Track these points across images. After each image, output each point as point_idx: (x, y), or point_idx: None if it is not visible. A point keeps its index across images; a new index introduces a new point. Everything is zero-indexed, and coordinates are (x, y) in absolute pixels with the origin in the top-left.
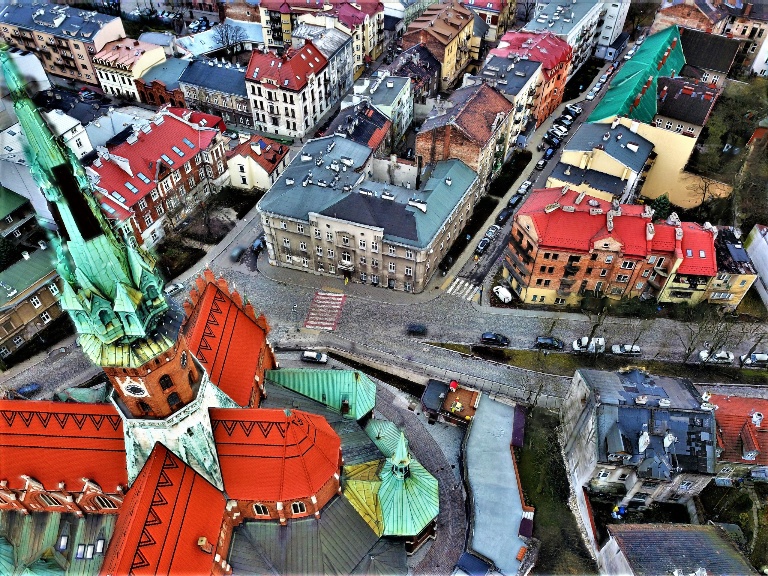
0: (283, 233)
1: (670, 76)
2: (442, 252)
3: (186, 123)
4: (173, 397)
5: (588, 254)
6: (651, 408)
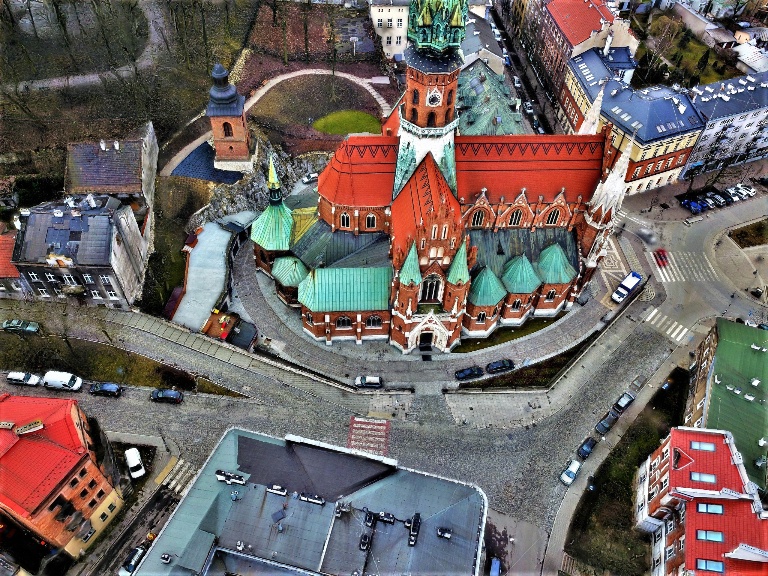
0: None
1: None
2: None
3: None
4: None
5: None
6: None
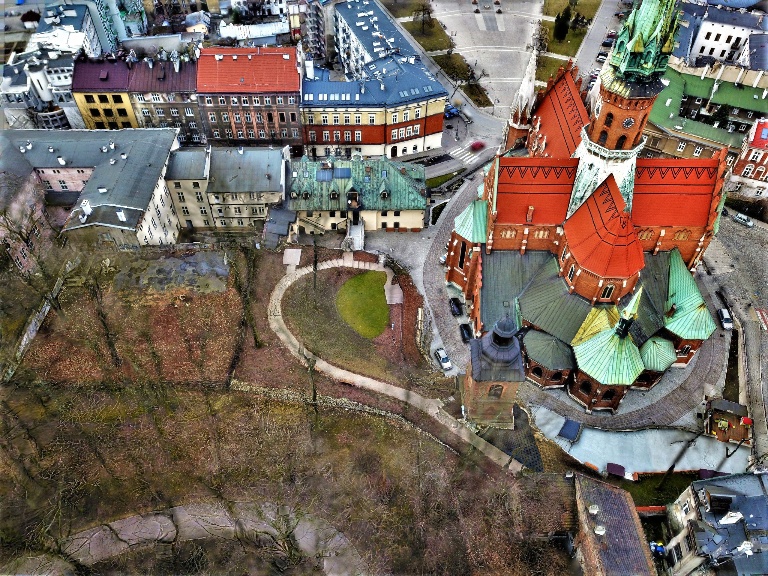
0: None
1: None
2: None
3: None
4: (605, 137)
5: None
6: None
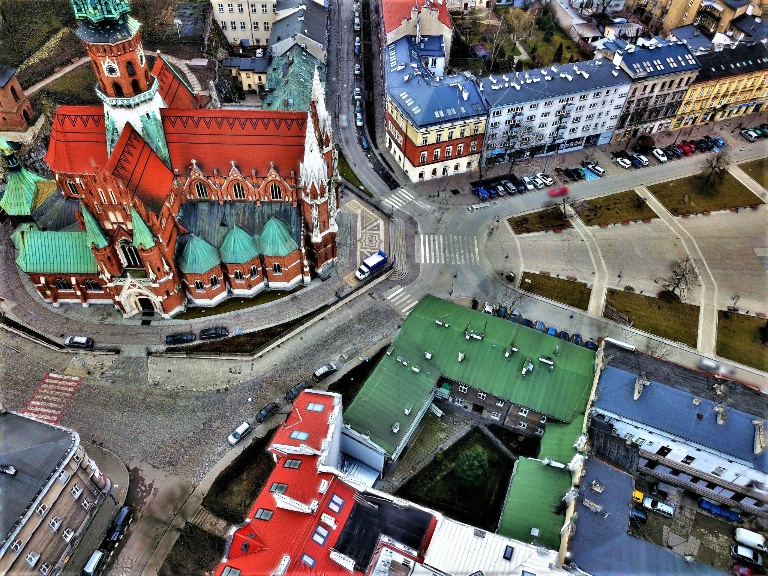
0: None
1: None
2: None
3: None
4: None
5: None
6: None
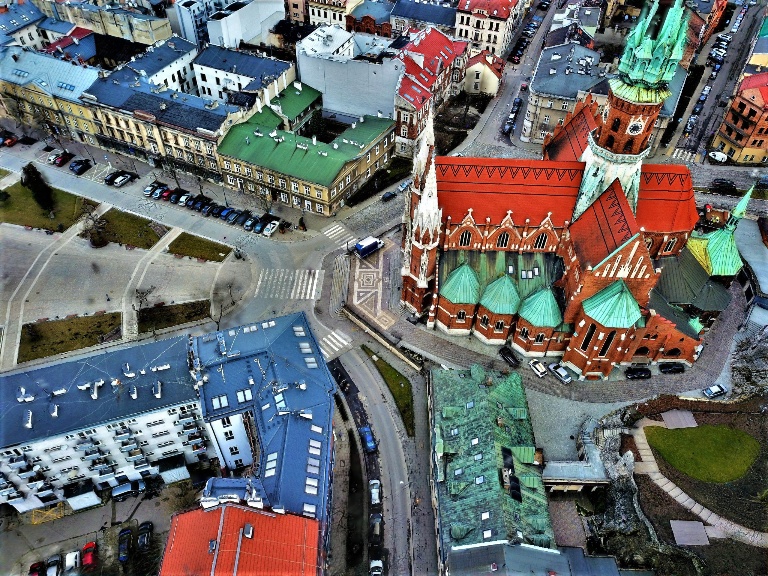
0: (547, 111)
1: None
2: None
3: (444, 35)
4: None
5: None
6: None
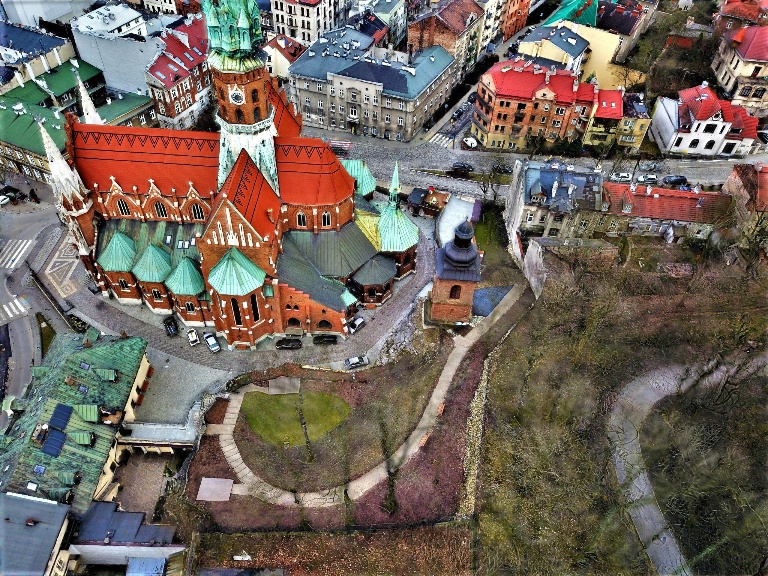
0: (306, 93)
1: (608, 1)
2: (426, 114)
3: None
4: (257, 113)
5: (531, 102)
6: (561, 171)
